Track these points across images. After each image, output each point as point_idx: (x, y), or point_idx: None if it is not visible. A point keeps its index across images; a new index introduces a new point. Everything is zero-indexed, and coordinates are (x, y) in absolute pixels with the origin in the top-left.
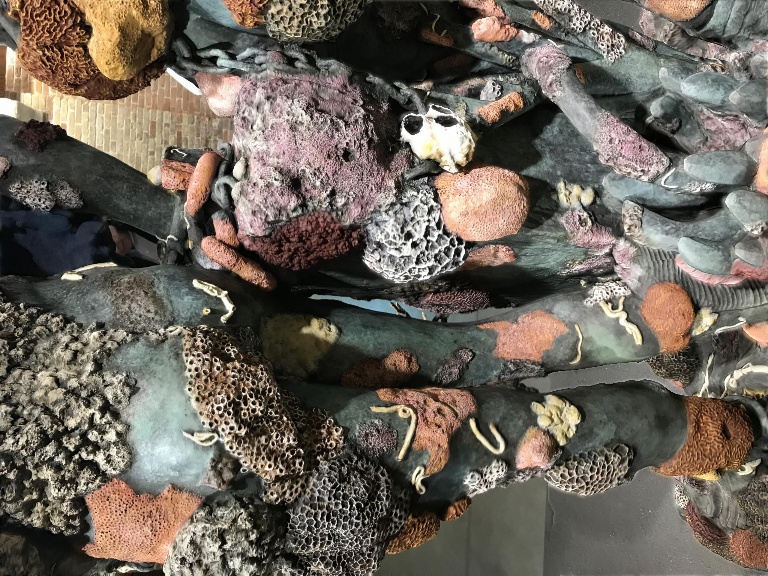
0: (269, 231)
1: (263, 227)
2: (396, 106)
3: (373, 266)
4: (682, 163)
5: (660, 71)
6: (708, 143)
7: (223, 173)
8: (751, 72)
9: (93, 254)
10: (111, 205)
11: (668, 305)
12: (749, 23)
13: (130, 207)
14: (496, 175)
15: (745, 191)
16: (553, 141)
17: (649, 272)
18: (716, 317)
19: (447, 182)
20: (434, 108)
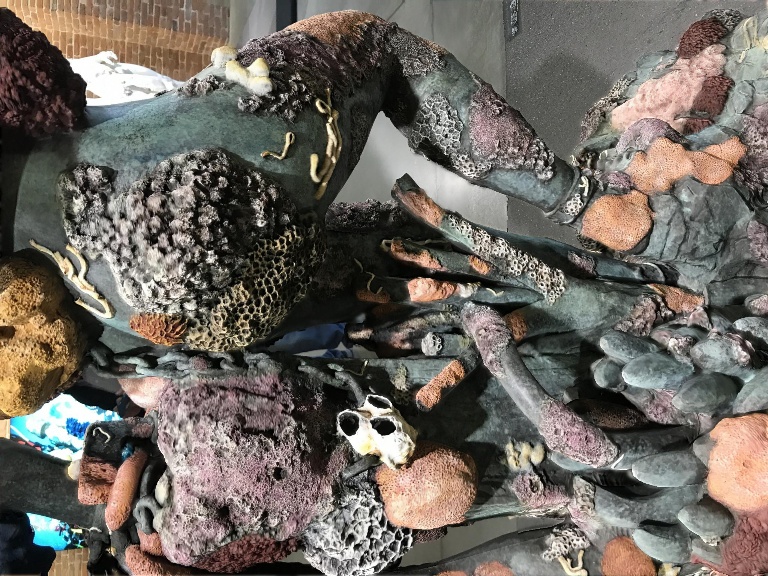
0: (196, 560)
1: (188, 560)
2: (331, 391)
3: (314, 566)
4: (630, 447)
5: (601, 341)
6: (655, 401)
7: (145, 485)
8: (691, 358)
9: (5, 563)
10: (25, 506)
11: (629, 565)
12: (684, 251)
13: (47, 505)
14: (440, 467)
15: (697, 507)
16: (498, 394)
17: (607, 526)
18: (679, 570)
19: (388, 477)
20: (371, 401)
